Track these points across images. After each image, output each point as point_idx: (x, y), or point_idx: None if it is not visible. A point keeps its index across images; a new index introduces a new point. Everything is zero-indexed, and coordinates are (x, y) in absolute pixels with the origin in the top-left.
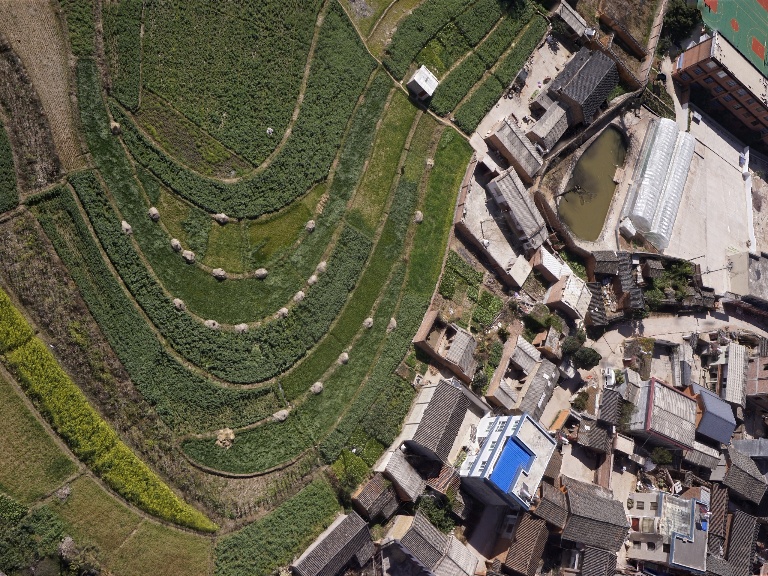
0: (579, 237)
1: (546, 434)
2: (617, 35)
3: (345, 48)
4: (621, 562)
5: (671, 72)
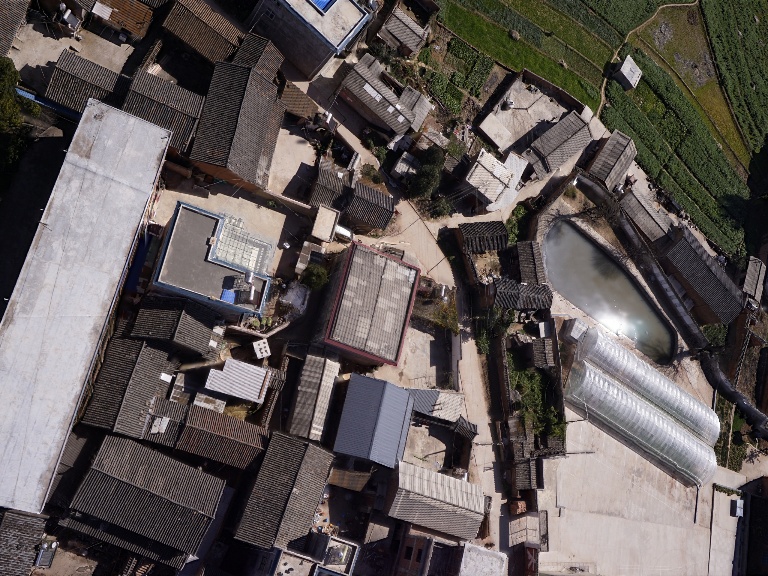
0: (546, 241)
1: (348, 36)
2: (766, 374)
3: (625, 4)
4: (158, 216)
5: (767, 476)
